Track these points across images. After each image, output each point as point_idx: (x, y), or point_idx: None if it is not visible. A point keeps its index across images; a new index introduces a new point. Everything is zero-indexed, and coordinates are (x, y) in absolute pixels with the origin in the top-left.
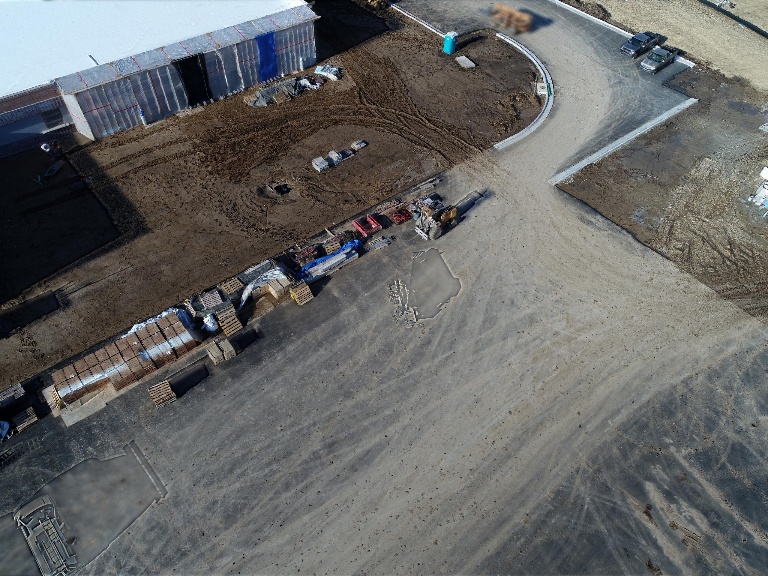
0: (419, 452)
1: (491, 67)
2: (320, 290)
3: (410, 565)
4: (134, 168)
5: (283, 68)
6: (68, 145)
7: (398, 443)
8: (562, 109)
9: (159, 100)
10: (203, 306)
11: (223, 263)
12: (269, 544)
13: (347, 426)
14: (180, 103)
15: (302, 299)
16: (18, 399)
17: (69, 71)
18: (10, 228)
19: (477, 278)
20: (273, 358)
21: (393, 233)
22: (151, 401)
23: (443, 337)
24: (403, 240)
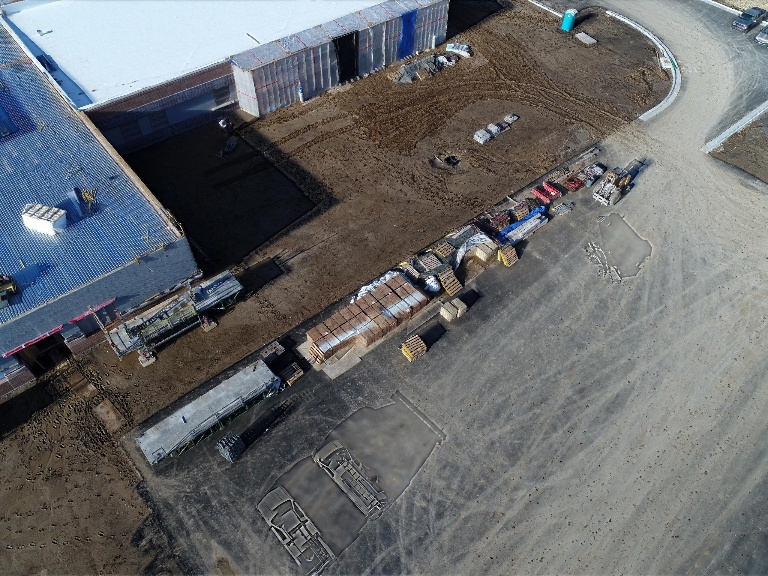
0: (664, 395)
1: (611, 43)
2: (522, 253)
3: (689, 493)
4: (306, 143)
5: (418, 46)
6: (235, 122)
7: (642, 388)
8: (691, 82)
9: (316, 77)
10: (424, 268)
11: (421, 230)
12: (556, 478)
13: (590, 374)
14: (332, 80)
15: (510, 261)
16: (279, 355)
17: (234, 49)
18: (209, 200)
19: (664, 239)
20: (500, 315)
21: (571, 200)
22: (401, 355)
23: (651, 293)
24: (583, 206)
